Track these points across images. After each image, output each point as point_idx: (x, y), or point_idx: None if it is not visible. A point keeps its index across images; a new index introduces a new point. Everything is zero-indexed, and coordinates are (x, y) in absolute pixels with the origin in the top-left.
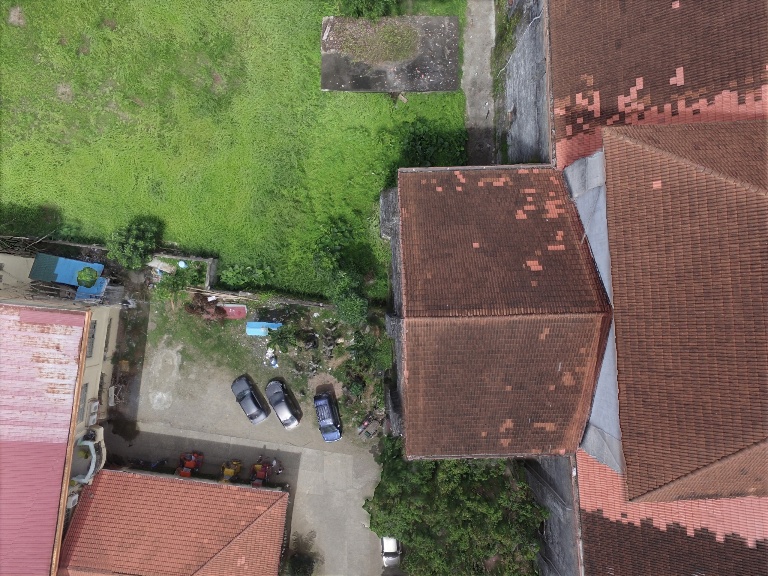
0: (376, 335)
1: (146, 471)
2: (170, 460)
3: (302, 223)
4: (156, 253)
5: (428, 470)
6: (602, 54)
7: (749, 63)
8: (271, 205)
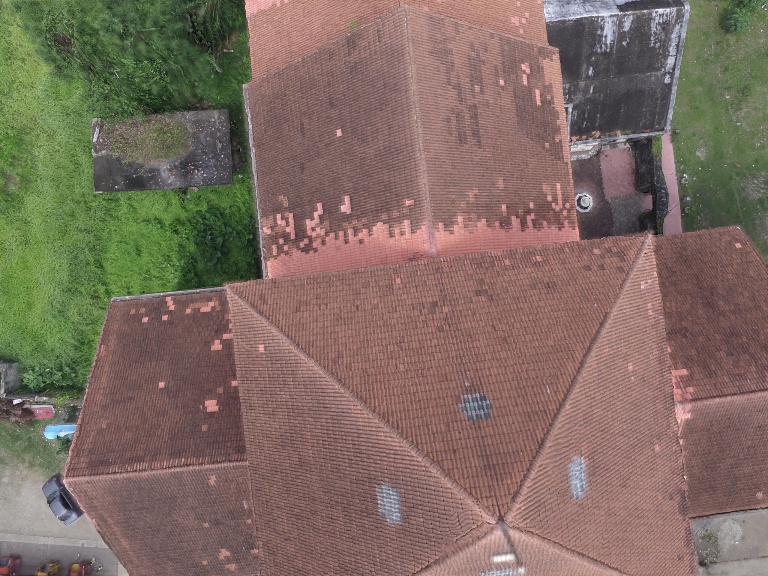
0: None
1: None
2: None
3: (102, 319)
4: None
5: None
6: (292, 176)
7: (394, 197)
8: (68, 304)
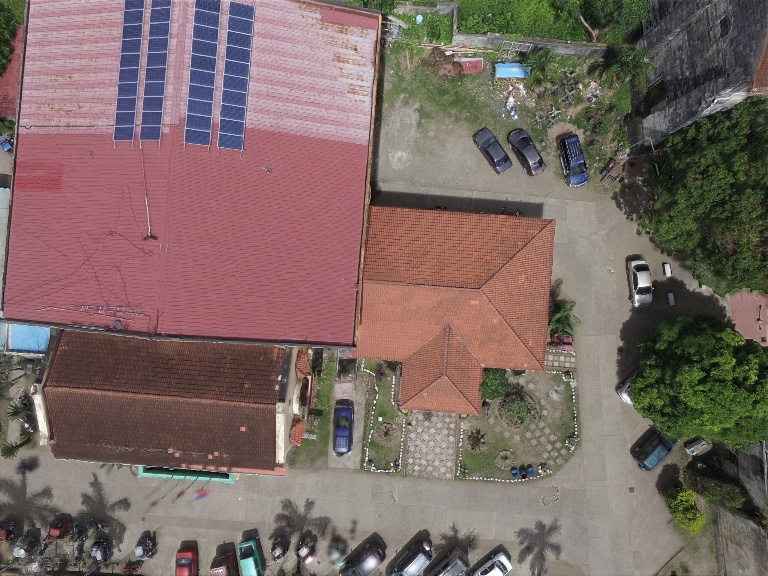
0: (613, 81)
1: None
2: None
3: None
4: None
5: (742, 135)
6: None
7: None
8: None
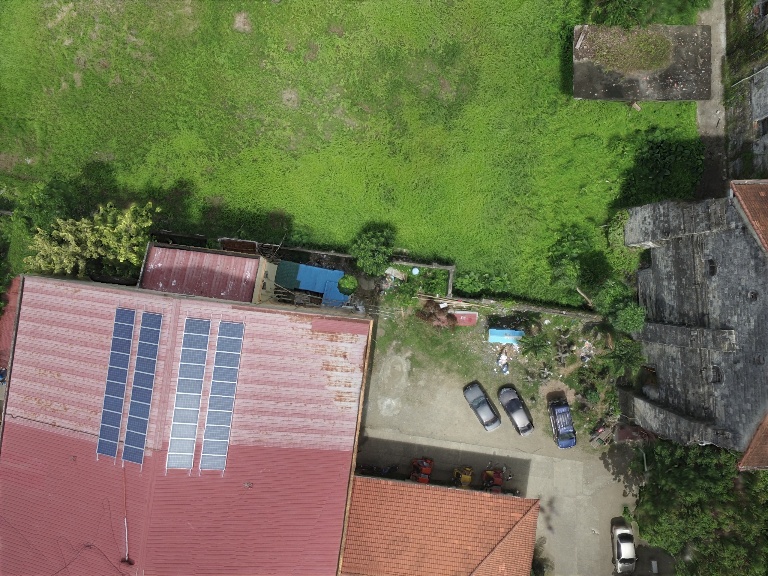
0: (608, 342)
1: (377, 477)
2: (400, 466)
3: (534, 230)
4: (394, 260)
5: (729, 479)
6: None
7: None
8: (505, 212)
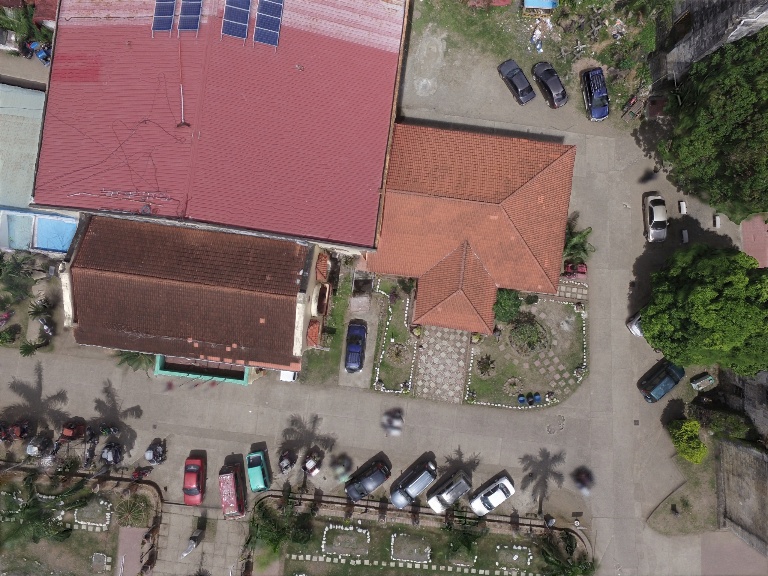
0: (639, 20)
1: None
2: None
3: None
4: None
5: (767, 57)
6: None
7: None
8: None
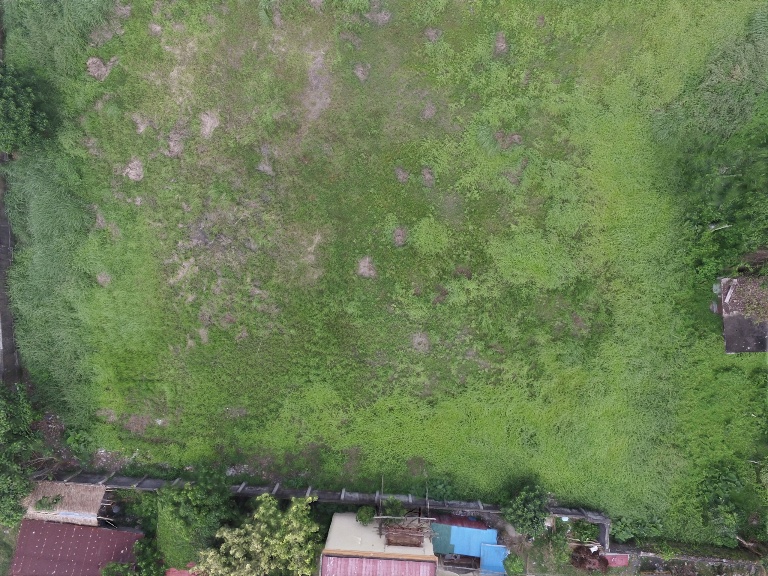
0: None
1: None
2: None
3: (681, 468)
4: None
5: None
6: None
7: None
8: (653, 454)
